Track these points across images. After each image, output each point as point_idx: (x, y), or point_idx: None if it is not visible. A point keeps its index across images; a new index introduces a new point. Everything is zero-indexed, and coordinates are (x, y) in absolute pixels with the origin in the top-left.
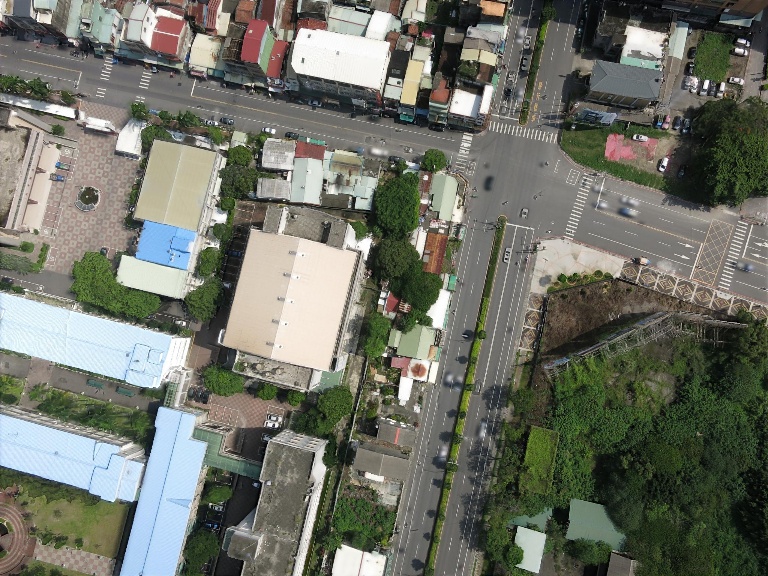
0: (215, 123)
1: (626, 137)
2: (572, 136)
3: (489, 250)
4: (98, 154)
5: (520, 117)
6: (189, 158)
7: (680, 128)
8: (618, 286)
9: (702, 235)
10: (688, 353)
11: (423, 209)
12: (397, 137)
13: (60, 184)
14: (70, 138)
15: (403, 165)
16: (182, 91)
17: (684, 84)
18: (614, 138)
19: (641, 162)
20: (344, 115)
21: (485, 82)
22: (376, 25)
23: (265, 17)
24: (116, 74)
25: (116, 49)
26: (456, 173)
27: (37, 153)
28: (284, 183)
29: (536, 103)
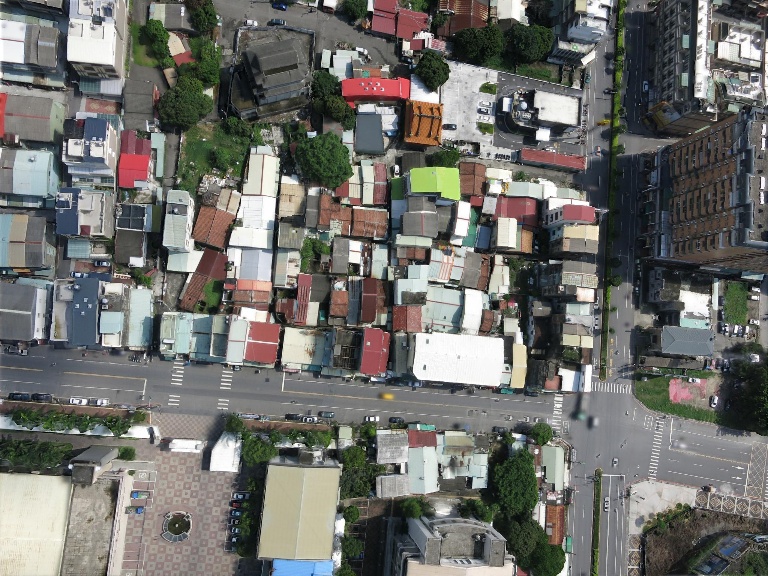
0: (314, 419)
1: (683, 380)
2: (643, 385)
3: (591, 503)
4: (181, 472)
5: (600, 374)
6: (313, 481)
7: (721, 367)
8: (696, 515)
9: (748, 457)
10: (754, 562)
11: (539, 483)
12: (497, 407)
13: (138, 515)
14: (144, 460)
15: (511, 439)
16: (271, 387)
17: (720, 329)
18: (674, 382)
19: (697, 401)
20: (444, 392)
21: (586, 363)
22: (472, 307)
23: (367, 313)
24: (190, 377)
25: (192, 353)
26: (559, 439)
27: (121, 499)
28: (404, 479)
29: (611, 359)
